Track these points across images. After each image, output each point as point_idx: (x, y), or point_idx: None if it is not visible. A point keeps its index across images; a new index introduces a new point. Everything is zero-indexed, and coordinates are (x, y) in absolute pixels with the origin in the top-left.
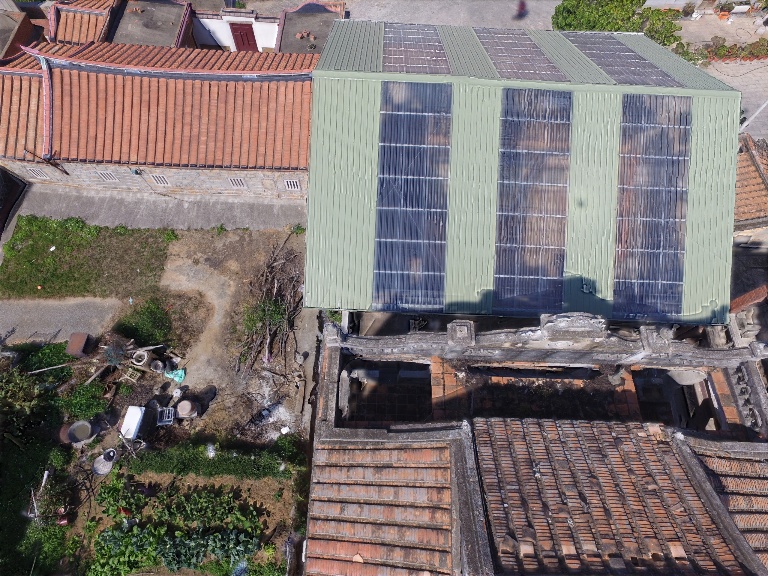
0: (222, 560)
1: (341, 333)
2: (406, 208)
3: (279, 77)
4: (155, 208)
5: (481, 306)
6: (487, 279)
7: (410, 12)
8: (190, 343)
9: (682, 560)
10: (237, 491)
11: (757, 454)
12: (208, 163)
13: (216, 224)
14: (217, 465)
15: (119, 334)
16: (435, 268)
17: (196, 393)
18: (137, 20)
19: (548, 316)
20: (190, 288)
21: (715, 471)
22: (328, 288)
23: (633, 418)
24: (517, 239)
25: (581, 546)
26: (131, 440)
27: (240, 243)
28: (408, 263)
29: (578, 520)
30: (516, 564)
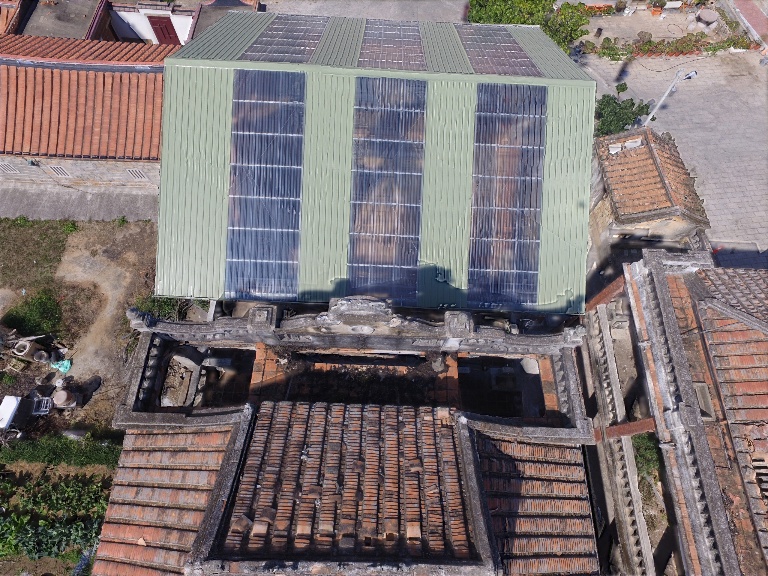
0: (85, 549)
1: (148, 318)
2: (259, 196)
3: None
4: (58, 200)
5: (334, 295)
6: (340, 268)
7: (340, 6)
8: (79, 334)
9: (413, 540)
10: (107, 481)
11: (558, 439)
12: (101, 154)
13: (118, 216)
14: (88, 455)
15: (1, 324)
16: (288, 257)
17: (80, 383)
18: (50, 12)
19: (337, 300)
20: (85, 279)
21: (513, 456)
22: (180, 276)
23: (449, 404)
24: (371, 228)
25: (318, 526)
26: (3, 429)
27: (141, 235)
28: (261, 251)
29: (325, 501)
30: (239, 543)
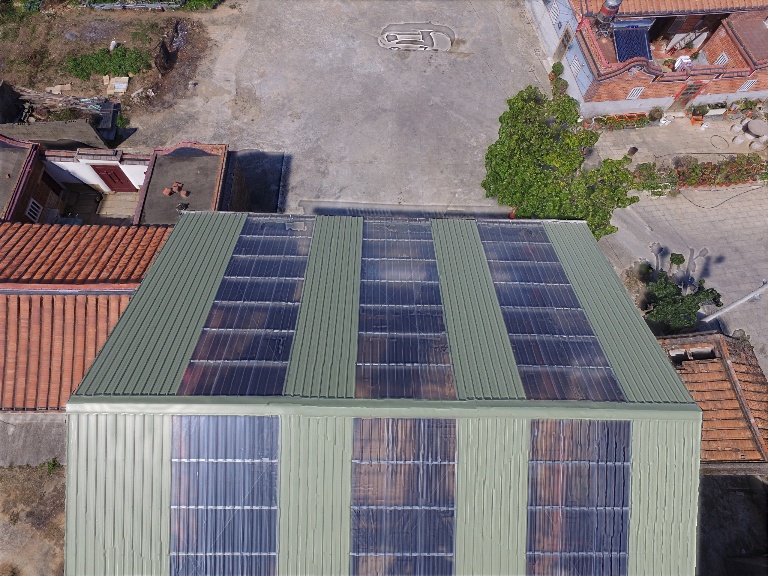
0: None
1: None
2: None
3: (107, 291)
4: None
5: None
6: None
7: (329, 124)
8: None
9: None
10: None
11: None
12: (16, 405)
13: (47, 458)
14: None
15: None
16: None
17: None
18: None
19: None
20: (1, 562)
21: None
22: None
23: None
24: None
25: None
26: None
27: None
28: None
29: None
30: None
